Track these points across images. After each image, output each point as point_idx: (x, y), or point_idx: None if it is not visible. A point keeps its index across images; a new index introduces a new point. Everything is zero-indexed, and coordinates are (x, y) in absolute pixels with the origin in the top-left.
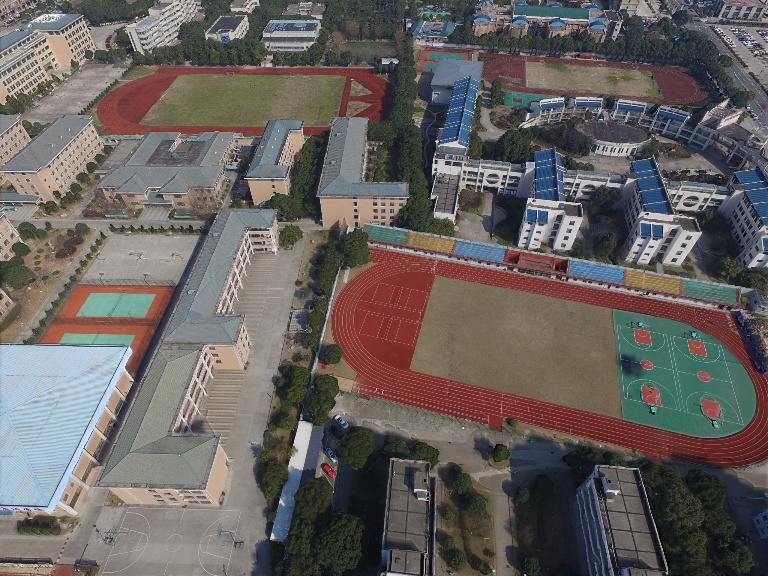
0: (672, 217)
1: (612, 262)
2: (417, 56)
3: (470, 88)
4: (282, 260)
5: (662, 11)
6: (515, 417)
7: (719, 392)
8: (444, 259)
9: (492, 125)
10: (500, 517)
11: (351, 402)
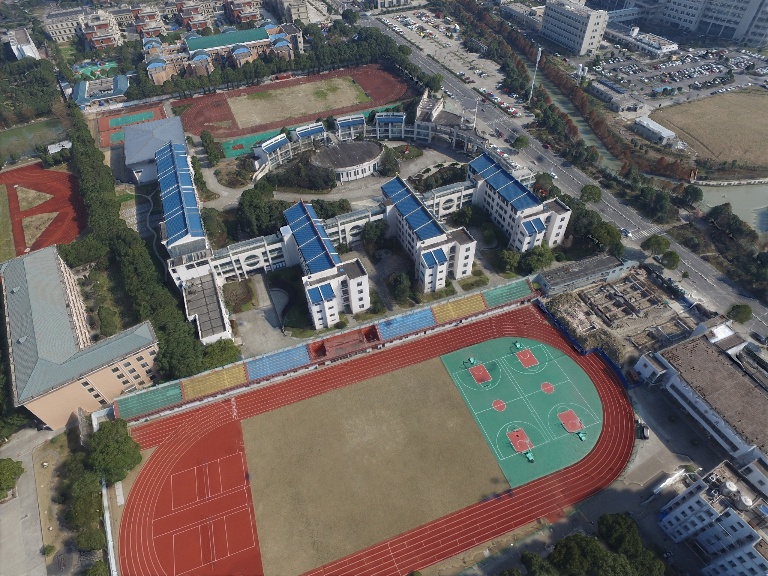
0: (445, 236)
1: (414, 301)
2: (95, 128)
3: (176, 156)
4: (4, 524)
5: (331, 13)
6: (415, 566)
7: (566, 397)
8: (241, 392)
9: (223, 187)
10: None
11: None
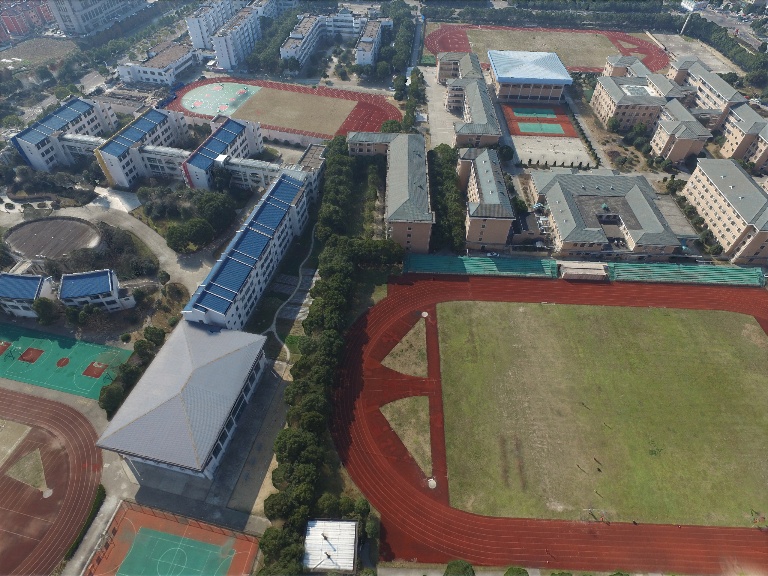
0: None
1: None
2: None
3: None
4: None
5: None
6: None
7: None
8: None
9: None
10: (330, 72)
11: (388, 94)
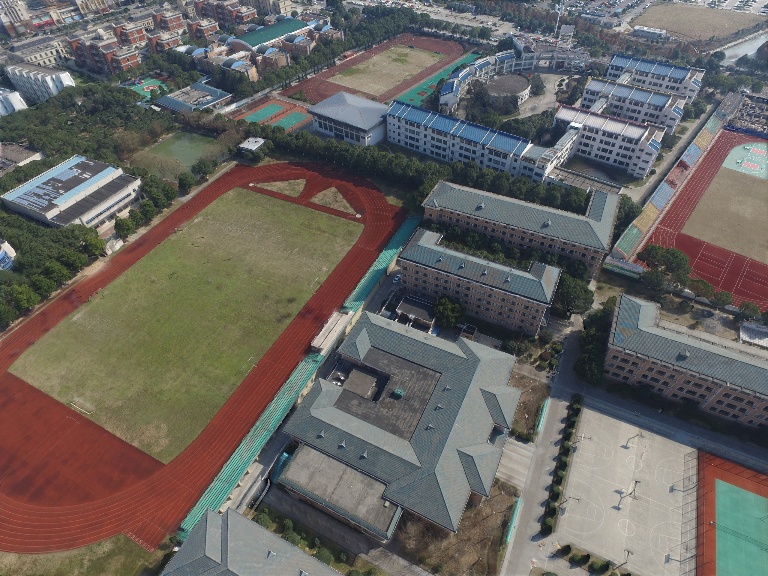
0: None
1: (668, 148)
2: None
3: None
4: None
5: None
6: None
7: None
8: (657, 221)
9: None
10: None
11: None
